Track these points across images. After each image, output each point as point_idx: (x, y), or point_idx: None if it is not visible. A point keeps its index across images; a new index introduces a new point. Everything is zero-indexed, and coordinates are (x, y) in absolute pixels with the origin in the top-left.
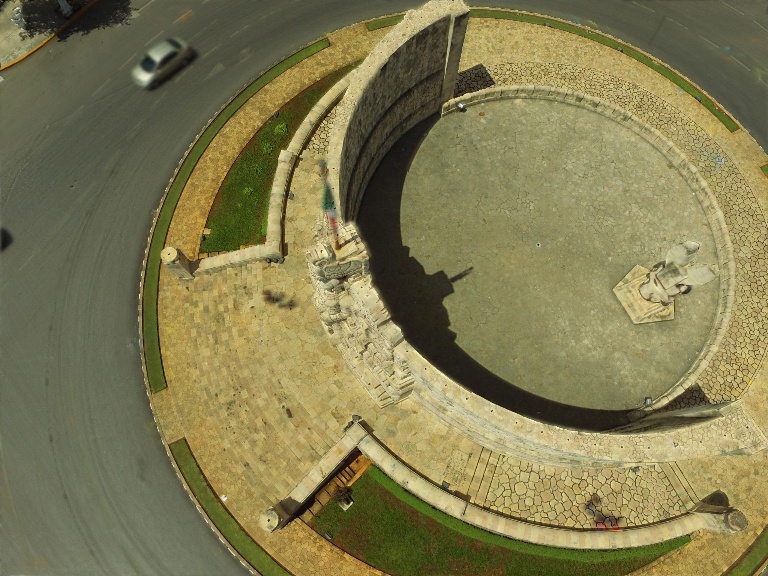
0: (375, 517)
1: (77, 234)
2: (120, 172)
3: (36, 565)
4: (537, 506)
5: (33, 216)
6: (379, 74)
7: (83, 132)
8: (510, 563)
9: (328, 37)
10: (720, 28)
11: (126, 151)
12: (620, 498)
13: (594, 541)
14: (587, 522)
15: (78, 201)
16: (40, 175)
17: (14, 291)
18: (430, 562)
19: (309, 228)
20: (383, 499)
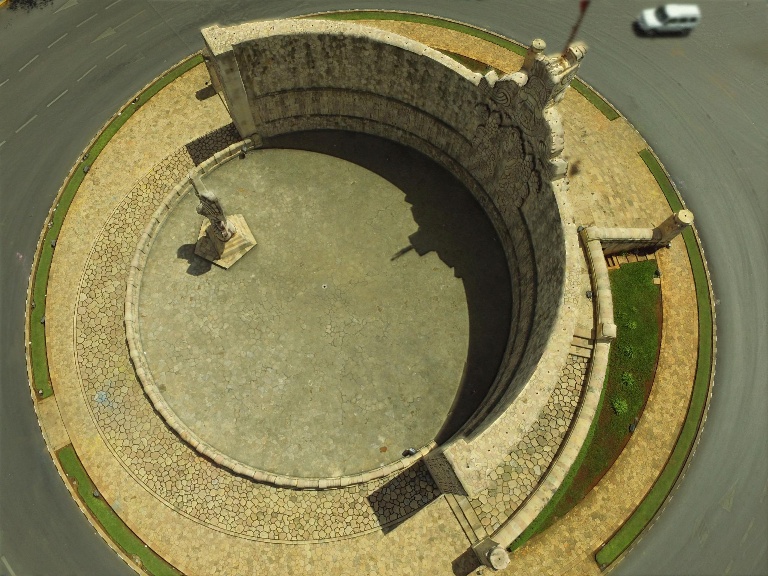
0: None
1: None
2: None
3: (678, 50)
4: None
5: None
6: None
7: None
8: None
9: (601, 572)
10: None
11: None
12: None
13: None
14: None
15: None
16: None
17: None
18: None
19: None
20: None
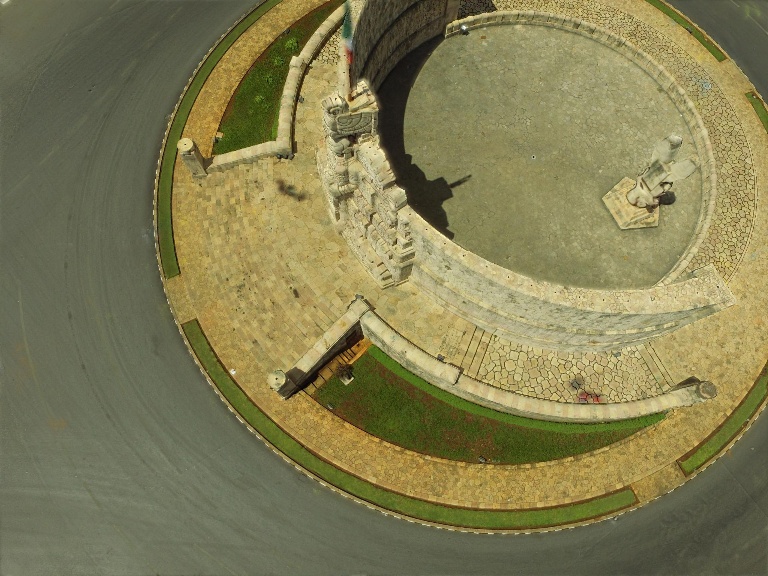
0: (374, 391)
1: (95, 134)
2: (136, 79)
3: (56, 426)
4: (525, 381)
5: (53, 116)
6: None
7: (101, 41)
8: (498, 434)
9: None
10: None
11: (142, 60)
12: (602, 379)
13: (576, 411)
14: (571, 397)
15: (96, 104)
16: (59, 79)
17: (34, 183)
18: (424, 432)
19: (318, 129)
20: (382, 376)
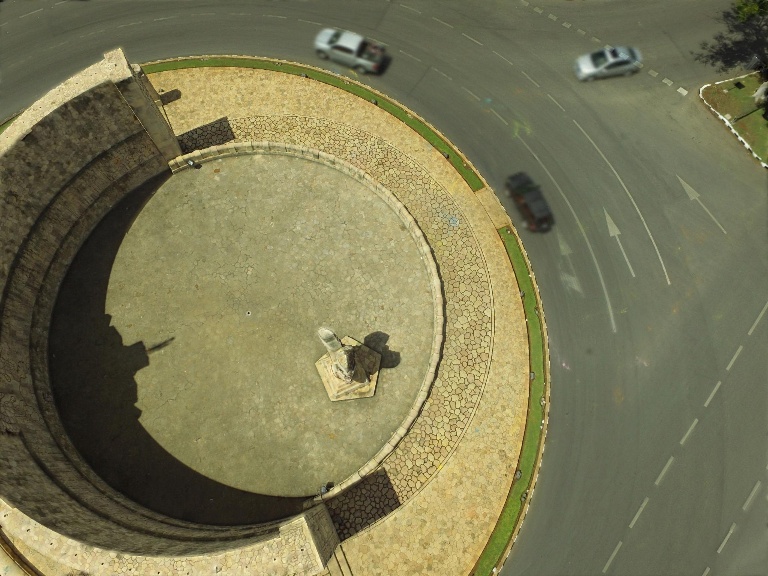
0: None
1: None
2: None
3: None
4: None
5: None
6: (23, 144)
7: None
8: None
9: None
10: (485, 79)
11: None
12: None
13: None
14: None
15: None
16: None
17: None
18: None
19: None
20: None
